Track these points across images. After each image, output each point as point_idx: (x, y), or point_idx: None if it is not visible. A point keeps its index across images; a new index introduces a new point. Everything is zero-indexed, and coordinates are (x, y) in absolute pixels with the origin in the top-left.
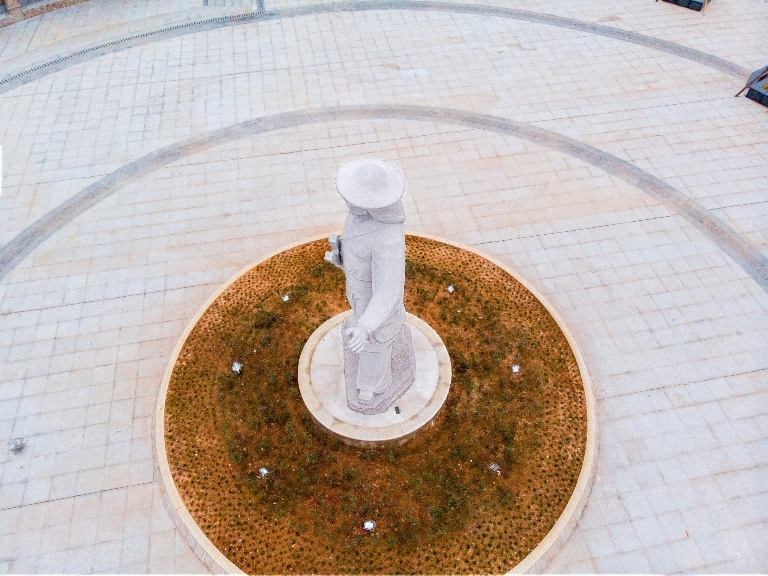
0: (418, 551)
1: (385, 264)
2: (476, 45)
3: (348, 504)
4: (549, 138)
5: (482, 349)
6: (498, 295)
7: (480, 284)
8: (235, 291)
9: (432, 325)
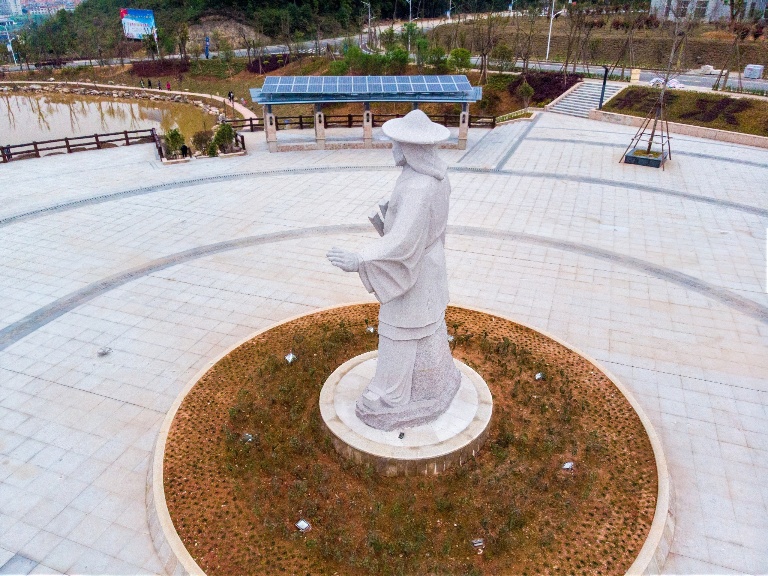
0: (334, 575)
1: (402, 206)
2: (697, 224)
3: (295, 491)
4: (745, 305)
5: (539, 435)
6: (591, 400)
7: (576, 384)
8: (334, 313)
9: (497, 397)
